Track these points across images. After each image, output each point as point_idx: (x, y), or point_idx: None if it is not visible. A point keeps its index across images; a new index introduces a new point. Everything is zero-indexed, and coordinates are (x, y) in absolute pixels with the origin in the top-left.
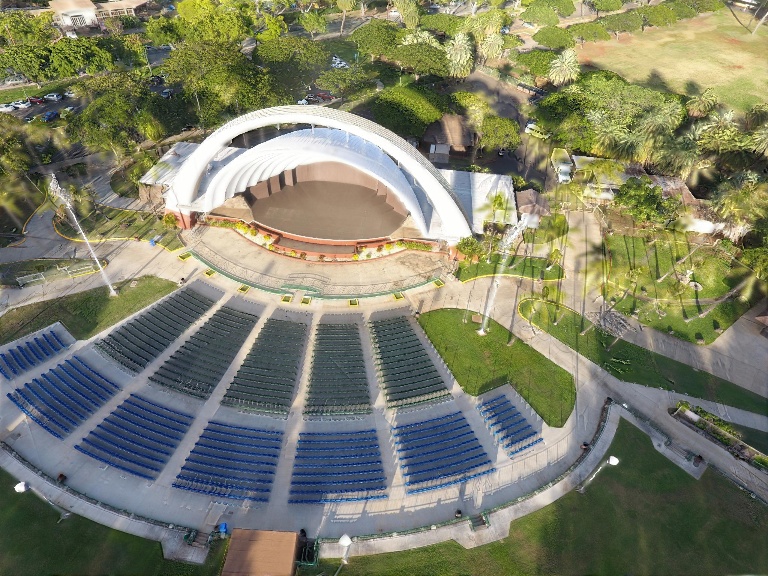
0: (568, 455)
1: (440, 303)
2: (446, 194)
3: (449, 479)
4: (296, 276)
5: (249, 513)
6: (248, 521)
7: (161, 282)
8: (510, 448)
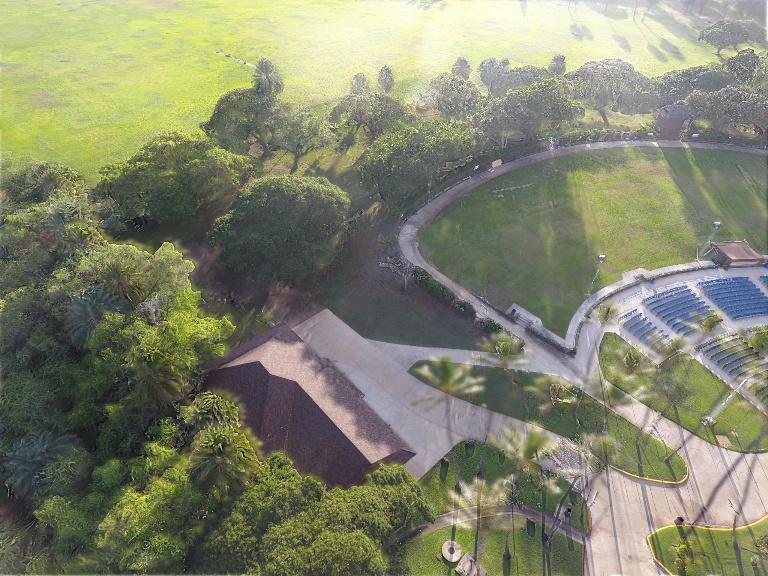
0: None
1: None
2: None
3: None
4: None
5: (762, 274)
6: (759, 272)
7: None
8: None
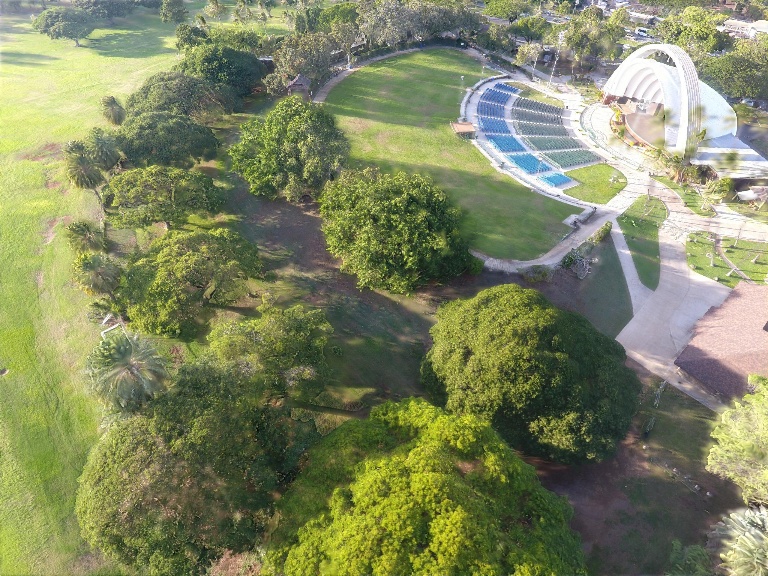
0: (549, 193)
1: (623, 170)
2: (687, 119)
3: (516, 164)
4: (599, 132)
5: None
6: None
7: (562, 104)
8: (541, 177)
